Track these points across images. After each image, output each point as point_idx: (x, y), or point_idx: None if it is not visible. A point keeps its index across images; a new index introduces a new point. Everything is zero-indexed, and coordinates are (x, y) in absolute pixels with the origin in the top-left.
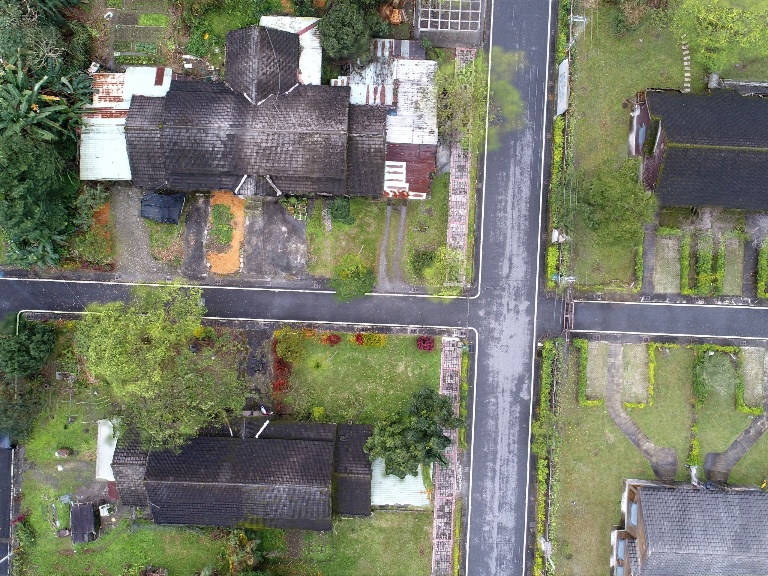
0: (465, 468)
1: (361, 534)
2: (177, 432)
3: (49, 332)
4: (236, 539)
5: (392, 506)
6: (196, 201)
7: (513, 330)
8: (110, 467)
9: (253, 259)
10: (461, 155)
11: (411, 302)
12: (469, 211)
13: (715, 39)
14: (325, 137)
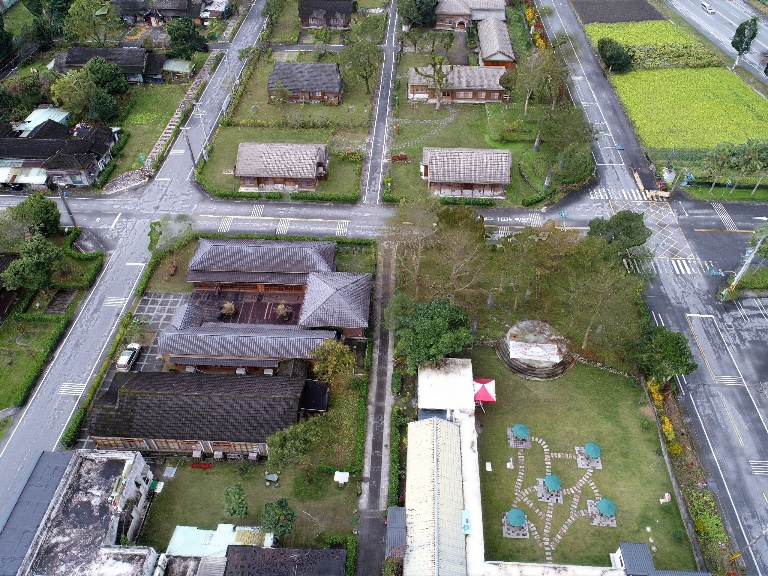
0: None
1: (156, 89)
2: None
3: None
4: None
5: None
6: (128, 27)
7: None
8: None
9: None
10: None
11: None
12: None
13: None
14: None
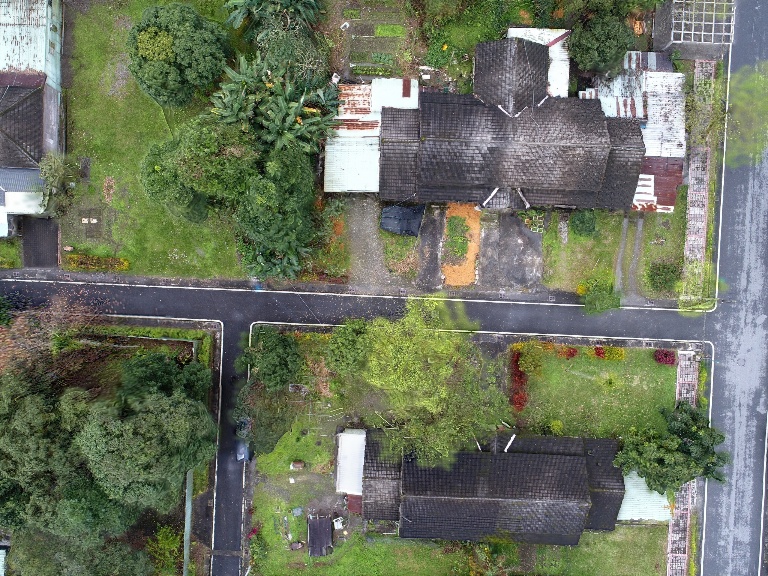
0: (700, 482)
1: (595, 548)
2: (426, 446)
3: (292, 344)
4: (484, 554)
5: (626, 520)
6: (432, 213)
7: (750, 344)
8: (351, 480)
9: (488, 271)
10: (699, 168)
11: (647, 315)
12: (707, 224)
13: None
14: (588, 150)
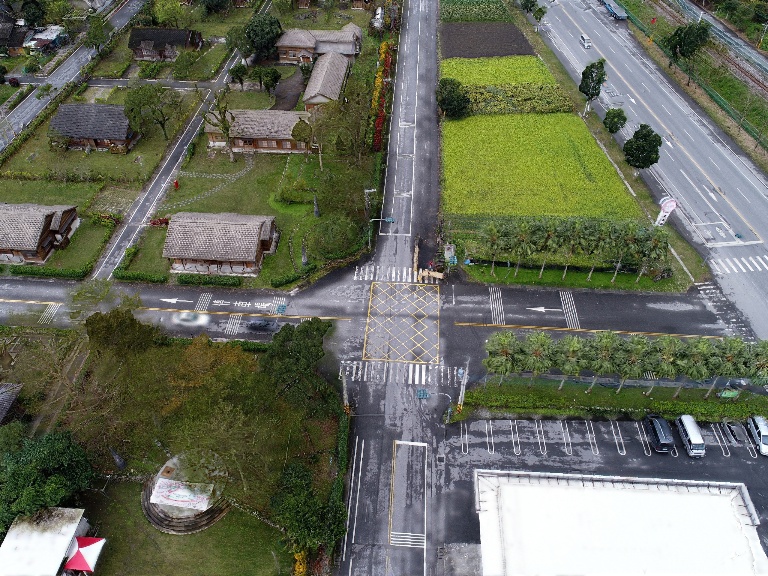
0: (6, 115)
1: None
2: None
3: None
4: None
5: None
6: None
7: (57, 83)
8: None
9: None
10: None
11: None
12: None
13: (158, 9)
14: (3, 25)
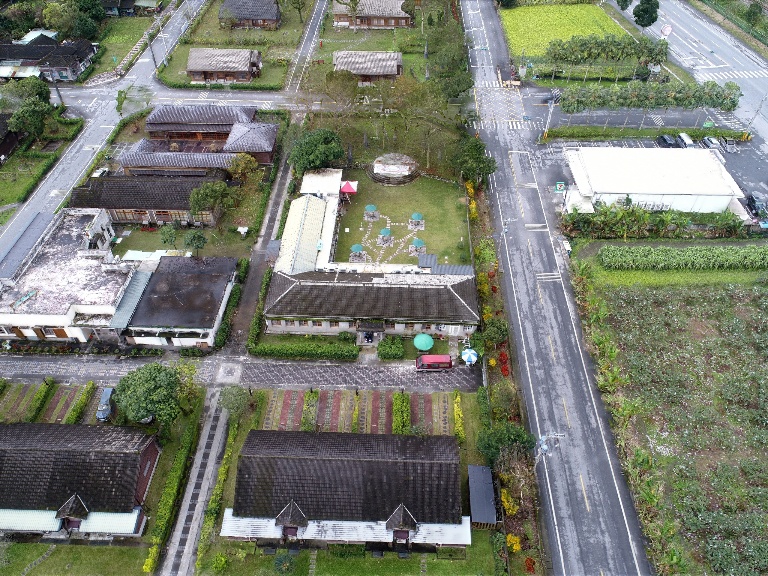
0: None
1: (129, 20)
2: None
3: None
4: None
5: None
6: None
7: None
8: None
9: None
10: None
11: None
12: None
13: None
14: None
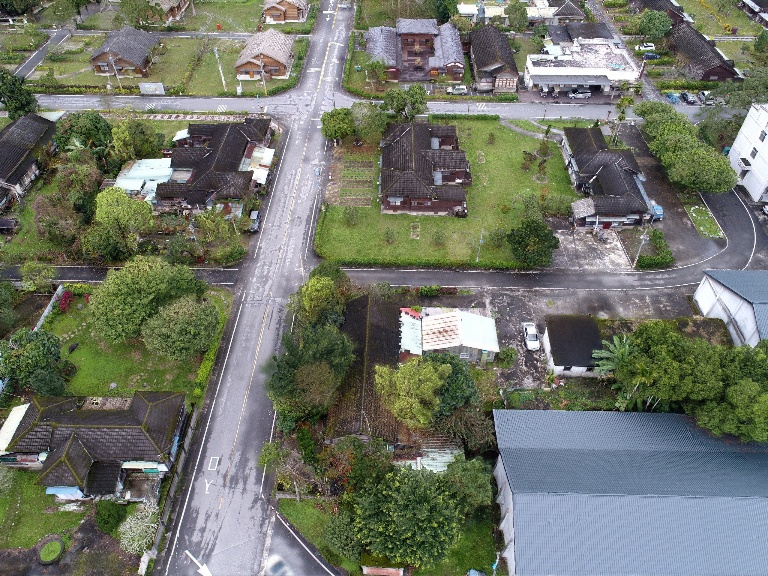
0: None
1: None
2: None
3: None
4: None
5: None
6: None
7: None
8: None
9: None
10: None
11: None
12: None
13: None
14: None
